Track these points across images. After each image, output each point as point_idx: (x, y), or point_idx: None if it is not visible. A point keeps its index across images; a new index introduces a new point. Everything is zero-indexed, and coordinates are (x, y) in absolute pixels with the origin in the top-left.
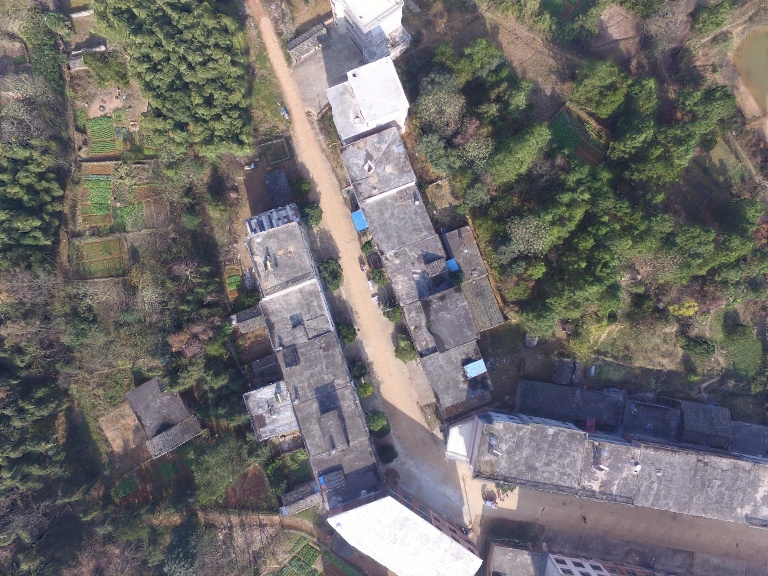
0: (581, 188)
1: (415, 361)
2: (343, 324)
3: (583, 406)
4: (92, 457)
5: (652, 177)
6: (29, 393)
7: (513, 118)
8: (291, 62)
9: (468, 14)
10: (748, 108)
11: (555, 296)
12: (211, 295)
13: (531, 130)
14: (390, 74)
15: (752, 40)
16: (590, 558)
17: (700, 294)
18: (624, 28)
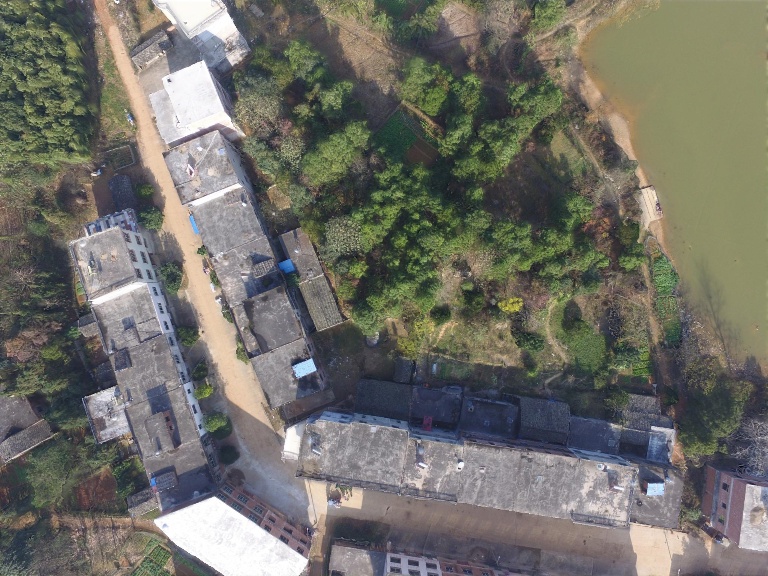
0: (394, 186)
1: None
2: (182, 326)
3: (420, 404)
4: None
5: (473, 173)
6: None
7: (330, 118)
8: (138, 69)
9: (310, 16)
10: (594, 101)
11: (373, 294)
12: (51, 300)
13: (344, 130)
14: (204, 78)
15: (598, 33)
16: (434, 556)
17: (530, 289)
18: (466, 25)
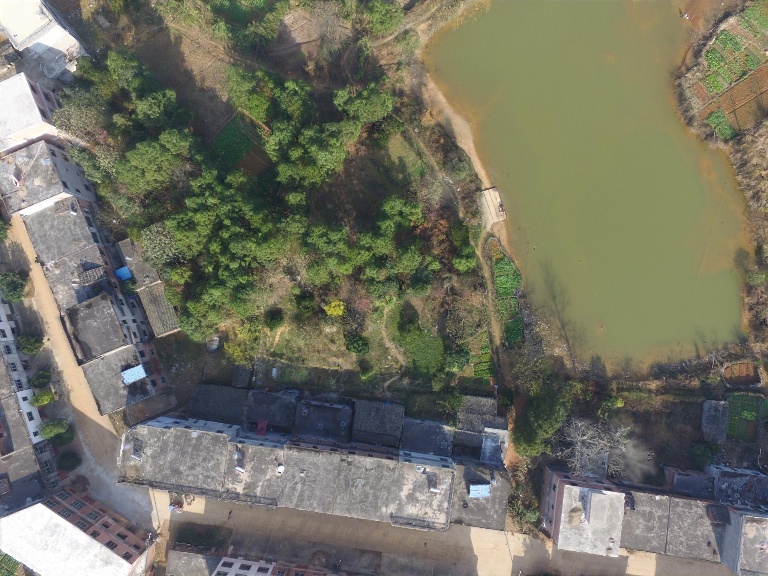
0: (207, 193)
1: None
2: (23, 335)
3: (255, 408)
4: None
5: (294, 178)
6: None
7: (149, 127)
8: None
9: (154, 26)
10: (436, 104)
11: (191, 300)
12: None
13: None
14: (23, 90)
15: (440, 36)
16: (274, 560)
17: None
18: (307, 31)
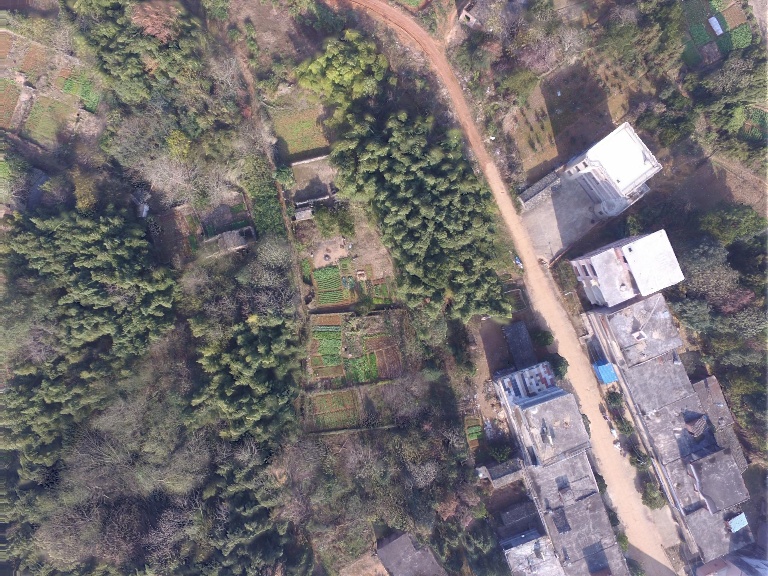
0: None
1: None
2: (595, 477)
3: None
4: None
5: None
6: (295, 564)
7: None
8: (520, 209)
9: (694, 157)
10: None
11: None
12: None
13: None
14: (665, 247)
15: None
16: None
17: None
18: None
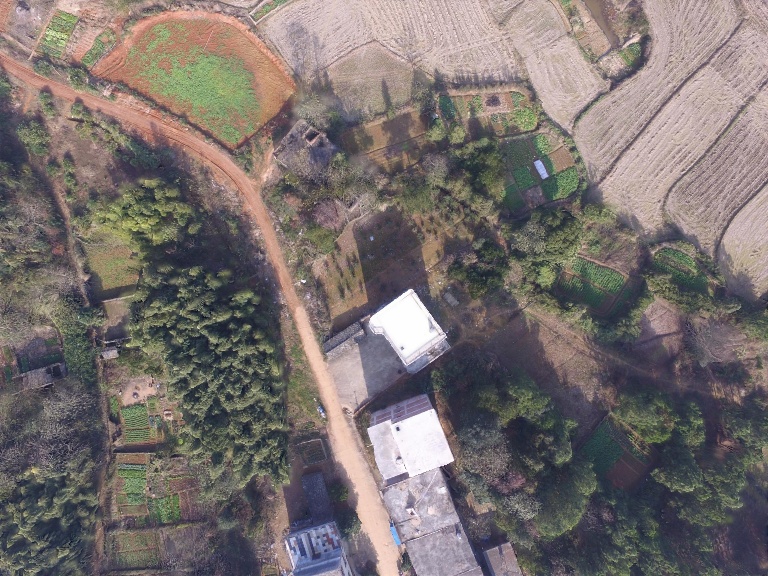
0: (629, 547)
1: None
2: None
3: None
4: None
5: None
6: None
7: None
8: (327, 356)
9: (507, 309)
10: None
11: None
12: None
13: (578, 485)
14: (434, 428)
15: None
16: None
17: None
18: (667, 323)
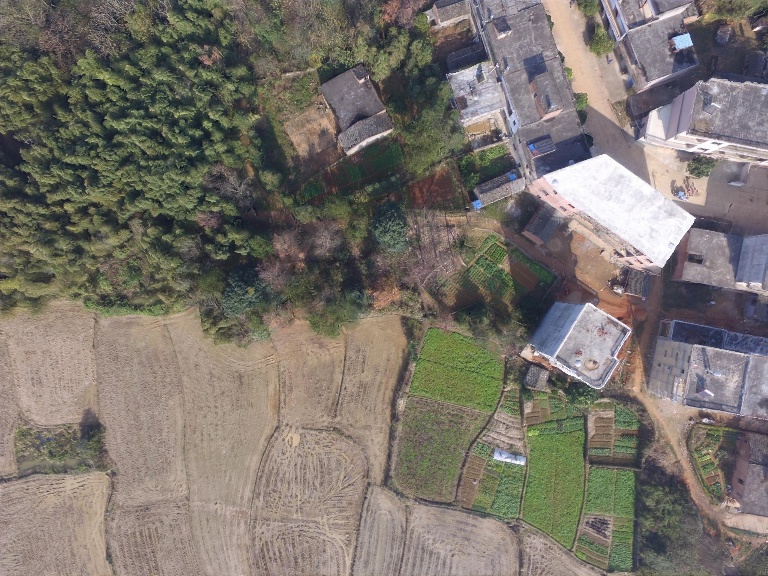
0: None
1: (606, 59)
2: None
3: None
4: (277, 161)
5: None
6: (234, 66)
7: None
8: None
9: None
10: None
11: None
12: None
13: None
14: None
15: None
16: None
17: None
18: None
